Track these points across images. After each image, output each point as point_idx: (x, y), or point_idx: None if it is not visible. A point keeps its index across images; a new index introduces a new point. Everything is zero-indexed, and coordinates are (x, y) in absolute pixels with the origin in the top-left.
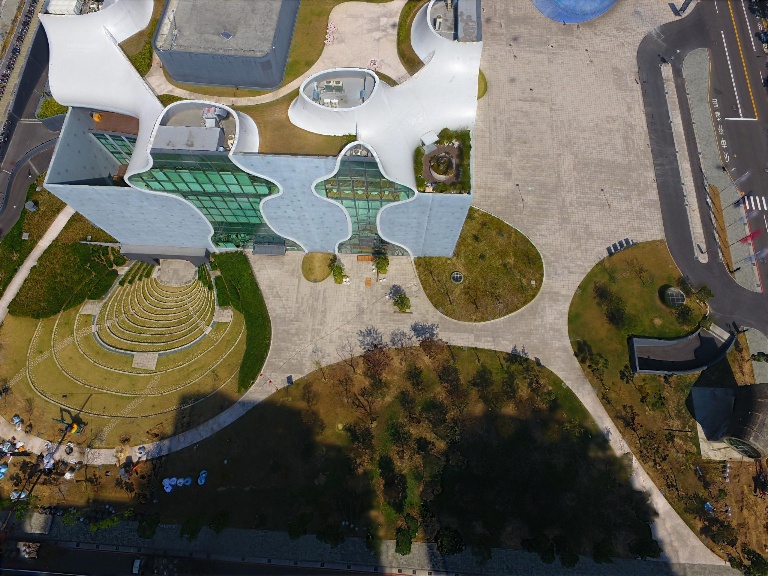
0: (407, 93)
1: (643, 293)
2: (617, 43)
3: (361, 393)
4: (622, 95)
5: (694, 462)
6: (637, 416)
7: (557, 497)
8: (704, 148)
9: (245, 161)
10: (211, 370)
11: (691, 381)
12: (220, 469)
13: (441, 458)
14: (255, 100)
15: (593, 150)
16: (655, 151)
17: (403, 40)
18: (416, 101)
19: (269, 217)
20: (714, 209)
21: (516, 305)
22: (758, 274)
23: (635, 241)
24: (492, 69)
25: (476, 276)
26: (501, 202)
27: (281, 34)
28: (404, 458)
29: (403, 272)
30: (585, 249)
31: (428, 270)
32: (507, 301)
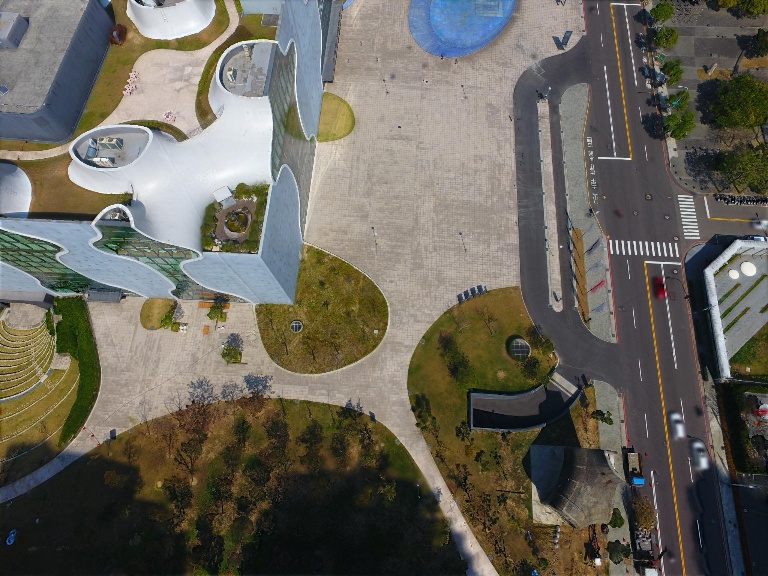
0: (197, 148)
1: (490, 344)
2: (495, 78)
3: (184, 449)
4: (493, 133)
5: (525, 526)
6: (470, 476)
7: (378, 562)
8: (572, 189)
9: (3, 224)
10: (40, 421)
11: (530, 438)
12: (32, 528)
13: (261, 519)
14: (42, 154)
15: (456, 191)
16: (521, 192)
17: (203, 91)
18: (205, 156)
19: (79, 269)
20: (575, 254)
21: (355, 356)
22: (615, 323)
23: (488, 288)
24: (362, 105)
25: (317, 325)
26: (353, 246)
27: (64, 87)
28: (223, 518)
29: (243, 320)
30: (435, 296)
31: (268, 318)
32: (346, 352)
